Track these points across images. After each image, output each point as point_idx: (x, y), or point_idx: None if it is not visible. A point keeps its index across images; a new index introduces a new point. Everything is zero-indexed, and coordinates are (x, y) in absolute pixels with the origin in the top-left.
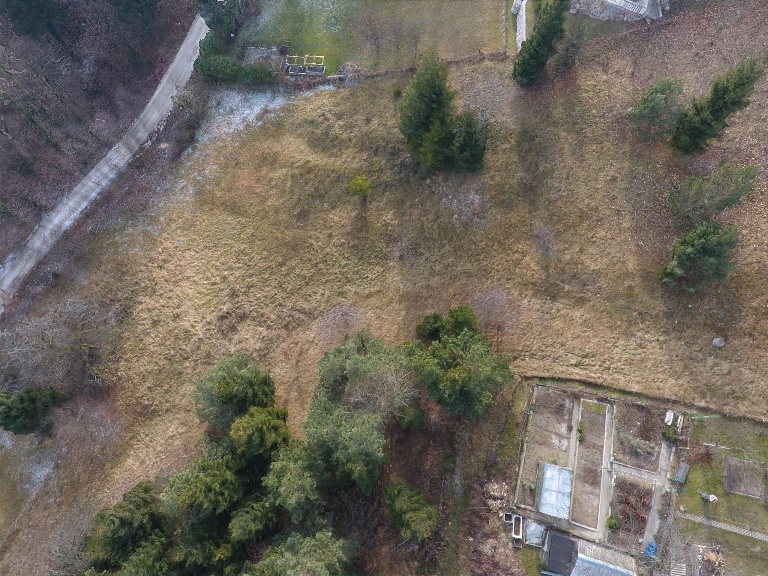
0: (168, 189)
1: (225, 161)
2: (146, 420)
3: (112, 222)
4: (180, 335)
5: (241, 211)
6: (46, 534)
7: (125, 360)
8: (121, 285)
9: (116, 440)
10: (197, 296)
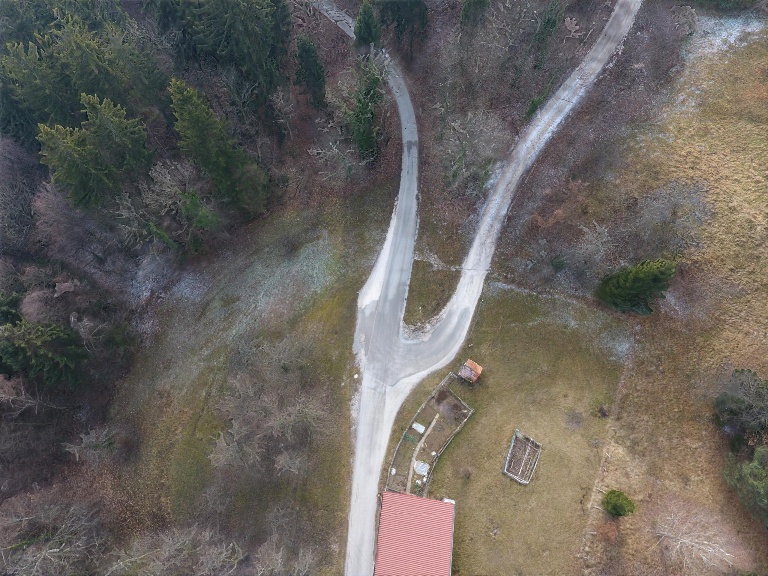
0: (666, 102)
1: (721, 77)
2: (734, 298)
3: (616, 131)
4: (744, 225)
5: (762, 119)
6: (659, 397)
7: (695, 246)
8: (660, 183)
9: (701, 317)
10: (745, 192)
